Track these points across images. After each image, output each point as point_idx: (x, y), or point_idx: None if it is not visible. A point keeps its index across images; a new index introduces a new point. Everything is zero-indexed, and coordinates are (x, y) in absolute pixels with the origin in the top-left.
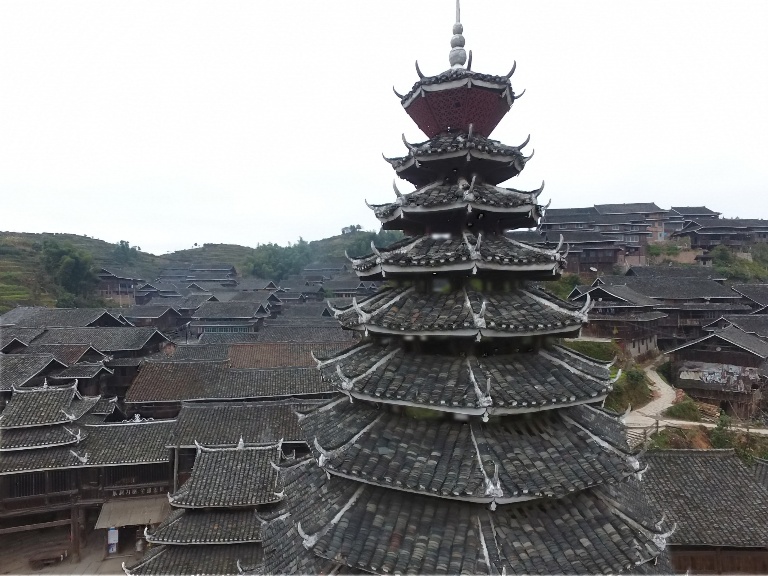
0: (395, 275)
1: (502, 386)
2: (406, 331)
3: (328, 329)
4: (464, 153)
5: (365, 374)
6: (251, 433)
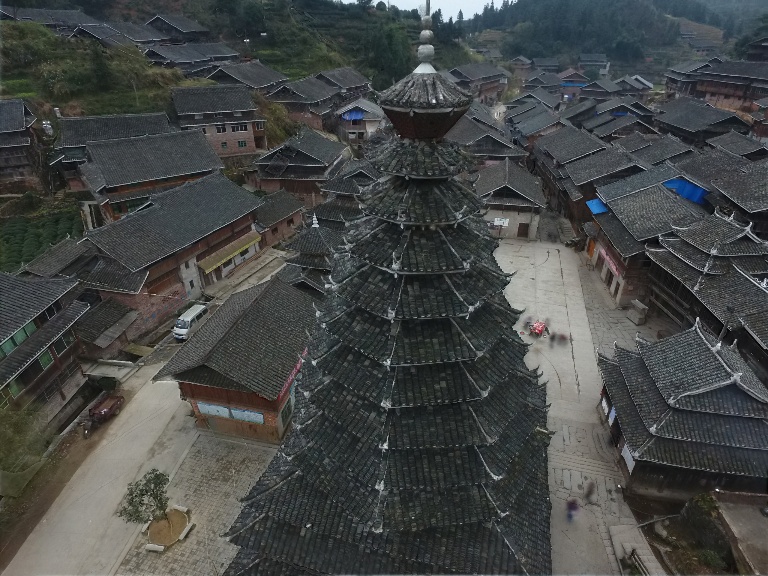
0: None
1: None
2: None
3: None
4: None
5: None
6: None
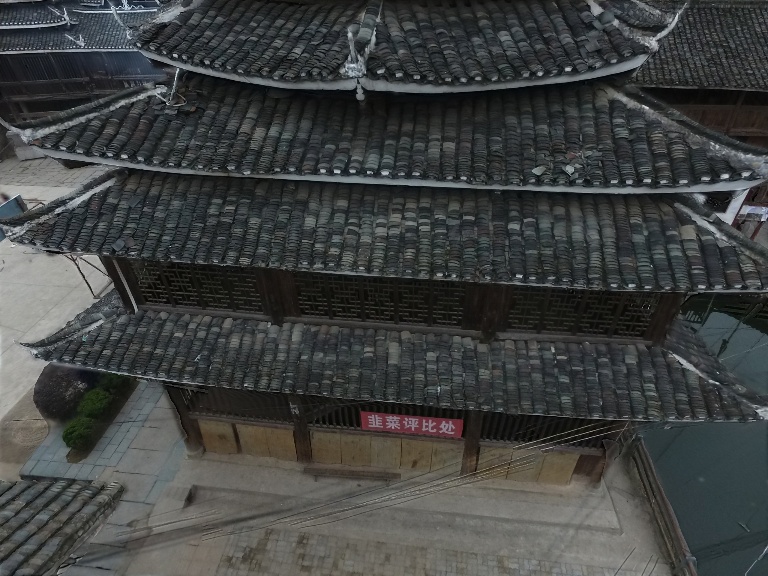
0: None
1: None
2: None
3: None
4: None
5: None
6: None
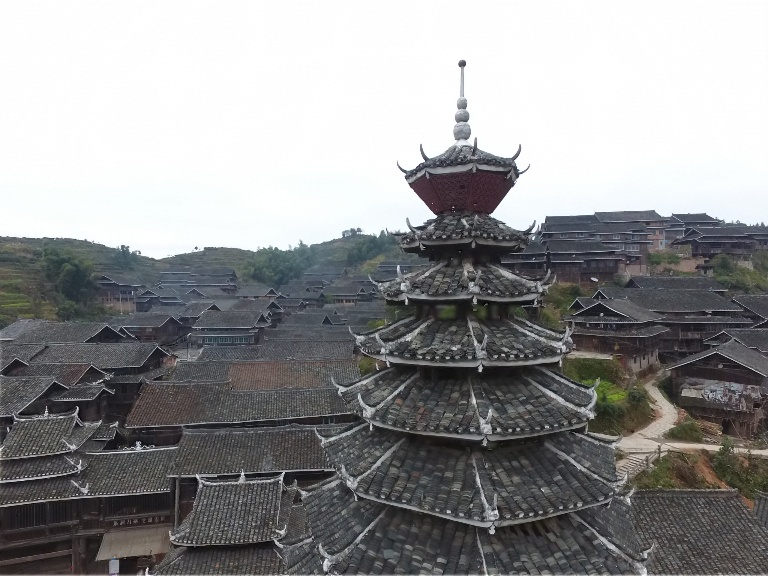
0: (400, 365)
1: (508, 491)
2: (411, 430)
3: (329, 343)
4: (469, 240)
5: (370, 470)
6: (252, 461)
